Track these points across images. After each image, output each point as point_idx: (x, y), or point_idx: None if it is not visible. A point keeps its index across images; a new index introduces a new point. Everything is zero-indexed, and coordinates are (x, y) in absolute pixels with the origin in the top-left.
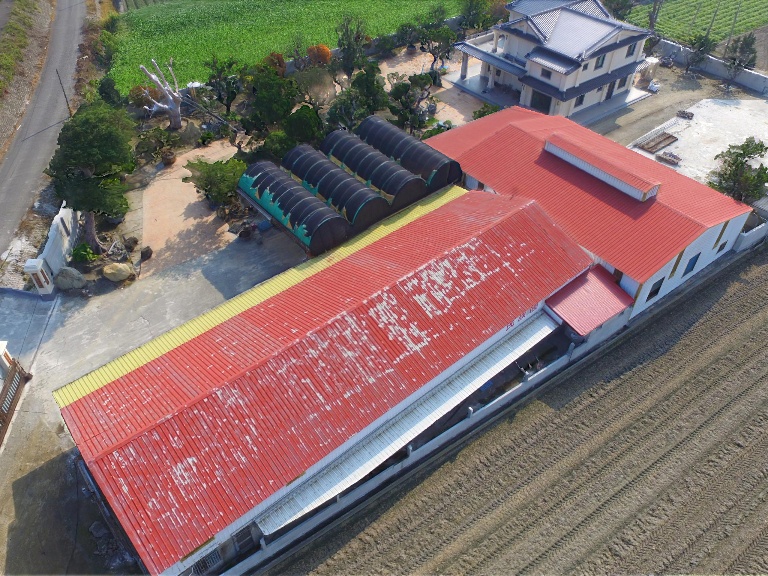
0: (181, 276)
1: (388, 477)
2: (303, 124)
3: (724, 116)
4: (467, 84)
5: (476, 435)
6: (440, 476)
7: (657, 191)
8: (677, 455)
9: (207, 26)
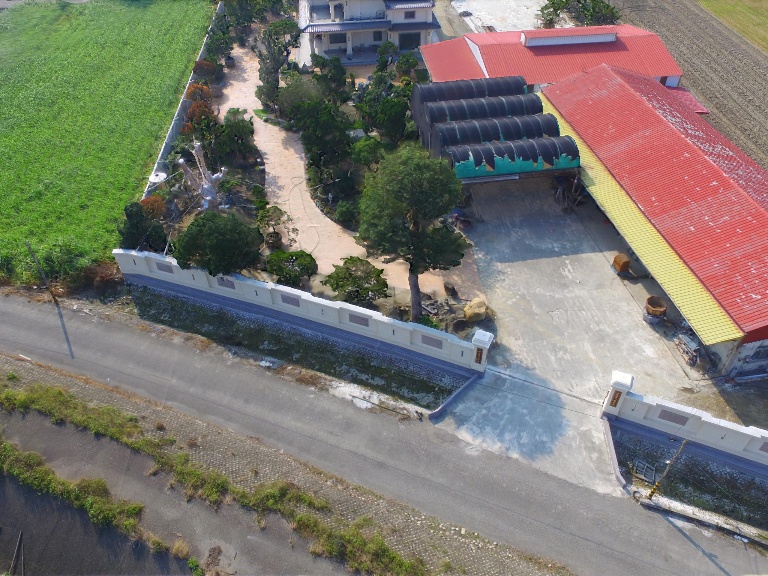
0: (500, 276)
1: None
2: None
3: (479, 6)
4: None
5: None
6: None
7: None
8: None
9: None
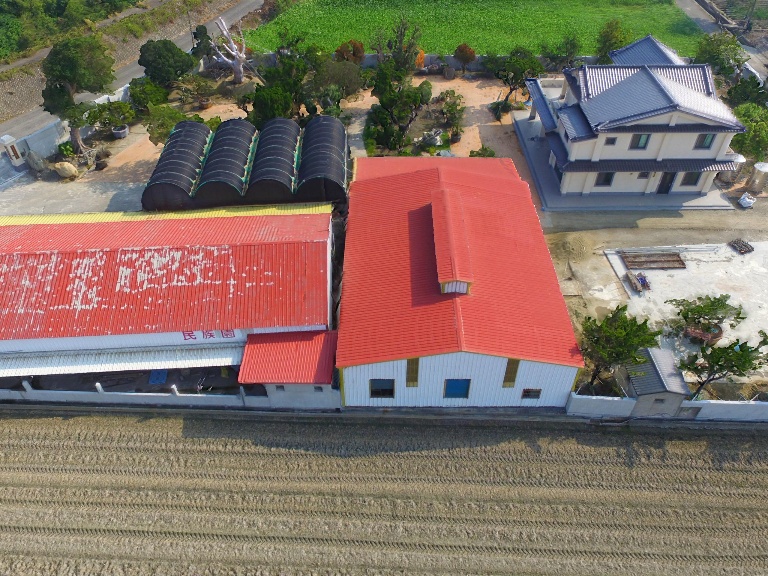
0: (100, 191)
1: (9, 398)
2: (262, 103)
3: None
4: (533, 126)
5: (104, 412)
6: (43, 423)
7: (468, 289)
8: (215, 542)
9: (375, 8)
